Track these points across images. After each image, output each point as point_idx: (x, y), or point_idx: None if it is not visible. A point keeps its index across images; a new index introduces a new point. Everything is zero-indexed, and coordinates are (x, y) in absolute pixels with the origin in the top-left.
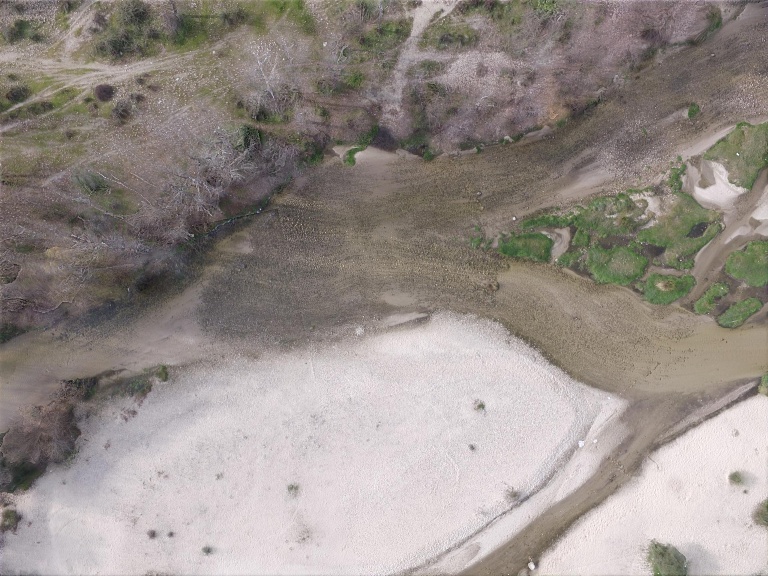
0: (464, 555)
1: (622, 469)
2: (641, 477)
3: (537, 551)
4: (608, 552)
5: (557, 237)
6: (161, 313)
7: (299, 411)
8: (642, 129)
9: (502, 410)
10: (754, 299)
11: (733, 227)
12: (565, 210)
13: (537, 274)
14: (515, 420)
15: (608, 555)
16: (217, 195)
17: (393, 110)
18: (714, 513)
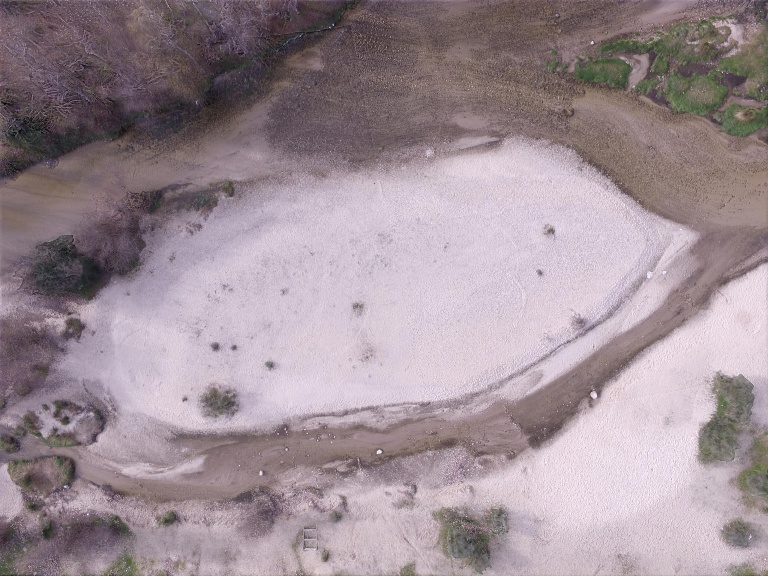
0: (526, 382)
1: (690, 302)
2: (709, 310)
3: (600, 381)
4: (672, 382)
5: (635, 63)
6: (229, 128)
7: (366, 230)
8: None
9: (572, 236)
10: None
11: None
12: (645, 36)
13: (613, 101)
14: (585, 246)
15: (672, 385)
16: None
17: None
18: None
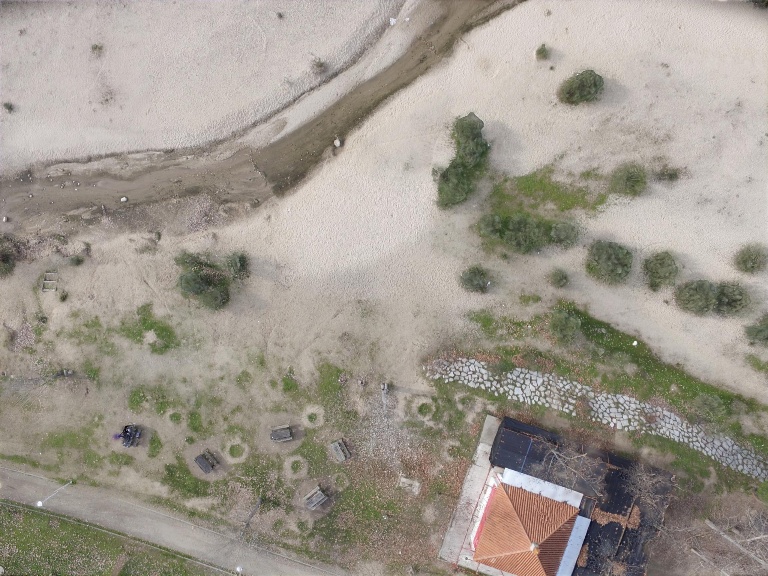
0: (270, 130)
1: (433, 50)
2: (451, 58)
3: (344, 129)
4: (412, 128)
5: None
6: None
7: None
8: None
9: None
10: None
11: None
12: None
13: None
14: None
15: (412, 131)
16: None
17: None
18: (520, 90)
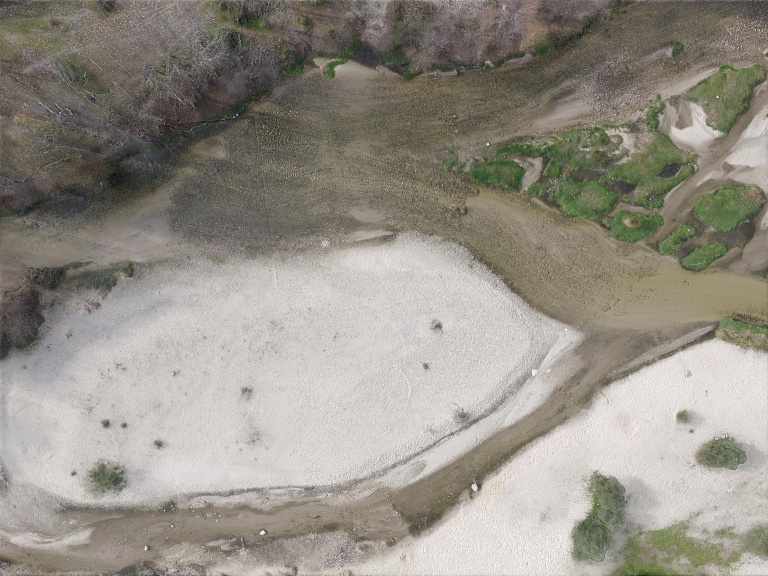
0: (410, 471)
1: (573, 401)
2: (591, 410)
3: (482, 473)
4: (551, 479)
5: (529, 166)
6: (131, 210)
7: (259, 316)
8: (624, 64)
9: (459, 332)
10: (720, 244)
11: (706, 170)
12: (539, 140)
13: (506, 202)
14: (471, 343)
15: (550, 482)
16: (192, 90)
17: (376, 25)
18: (659, 450)
